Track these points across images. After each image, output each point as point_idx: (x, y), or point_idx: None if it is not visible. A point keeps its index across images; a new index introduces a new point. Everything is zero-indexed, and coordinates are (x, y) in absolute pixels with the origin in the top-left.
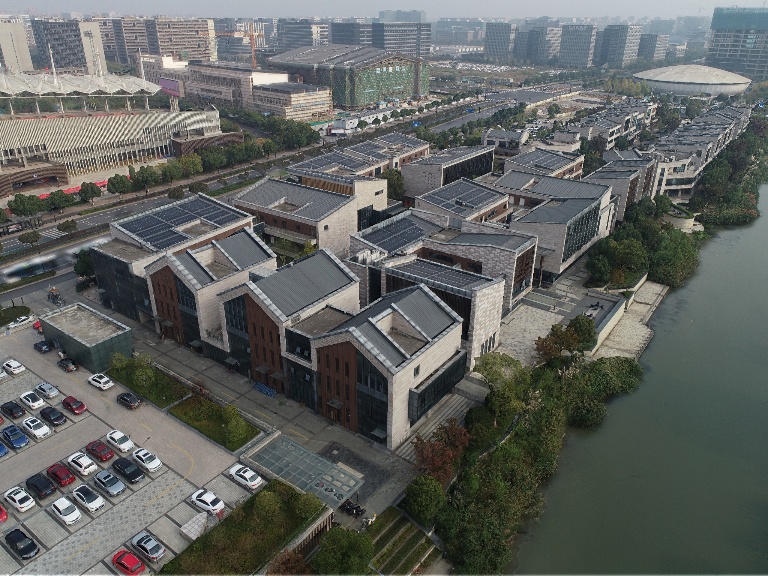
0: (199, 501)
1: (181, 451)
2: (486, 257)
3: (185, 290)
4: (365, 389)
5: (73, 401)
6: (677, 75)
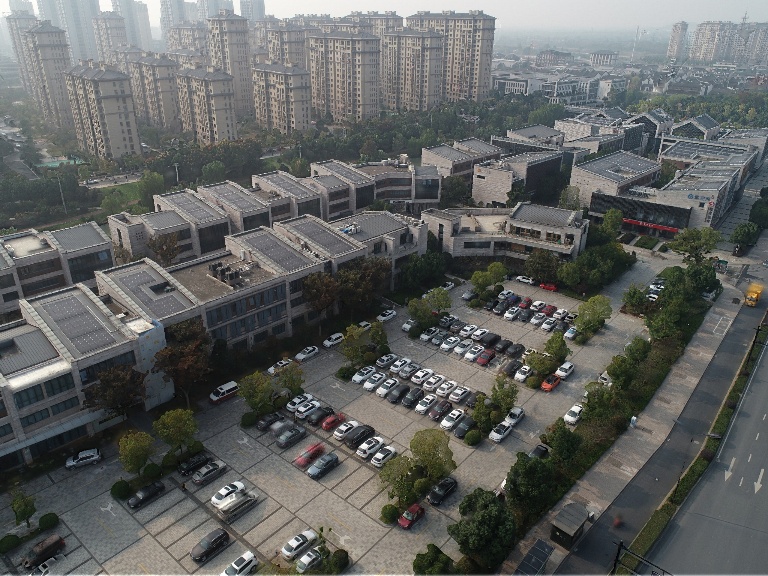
0: None
1: None
2: None
3: None
4: None
5: None
6: None
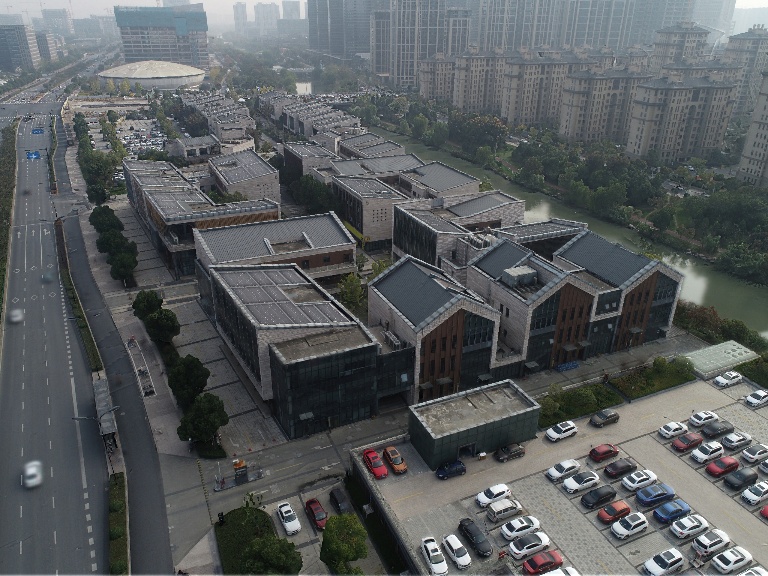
0: (763, 399)
1: (688, 403)
2: (505, 214)
3: (477, 325)
4: (658, 302)
5: (606, 447)
6: (150, 71)
